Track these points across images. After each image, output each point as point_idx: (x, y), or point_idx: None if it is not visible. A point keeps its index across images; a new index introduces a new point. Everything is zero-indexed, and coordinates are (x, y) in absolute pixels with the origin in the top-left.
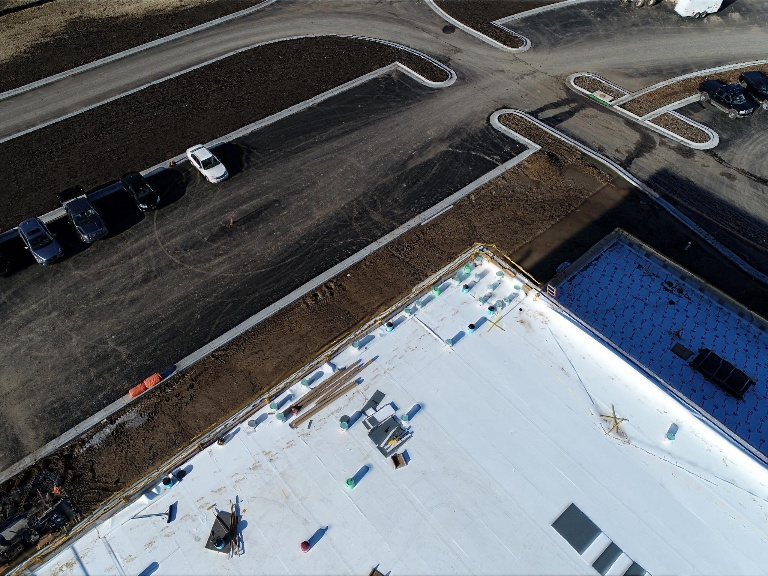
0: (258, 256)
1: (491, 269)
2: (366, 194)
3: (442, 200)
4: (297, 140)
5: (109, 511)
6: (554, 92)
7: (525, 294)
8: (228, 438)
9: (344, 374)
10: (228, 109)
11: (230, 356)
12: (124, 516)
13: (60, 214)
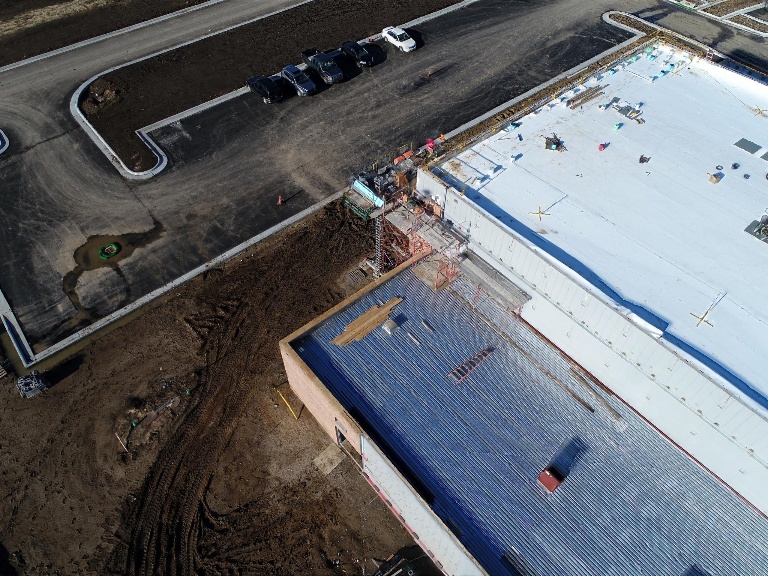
0: (454, 94)
1: (665, 50)
2: (521, 61)
3: (579, 64)
4: (459, 28)
5: None
6: (648, 1)
7: (691, 60)
8: (537, 112)
9: (592, 90)
10: (400, 8)
11: (455, 145)
12: (495, 138)
13: (302, 68)
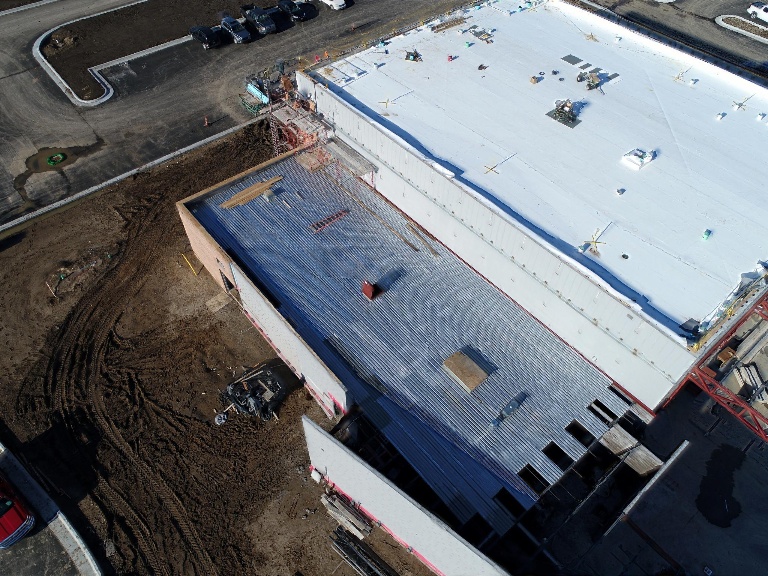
0: None
1: None
2: None
3: None
4: None
5: (359, 48)
6: None
7: None
8: (406, 34)
9: None
10: None
11: None
12: (365, 52)
13: (241, 22)
